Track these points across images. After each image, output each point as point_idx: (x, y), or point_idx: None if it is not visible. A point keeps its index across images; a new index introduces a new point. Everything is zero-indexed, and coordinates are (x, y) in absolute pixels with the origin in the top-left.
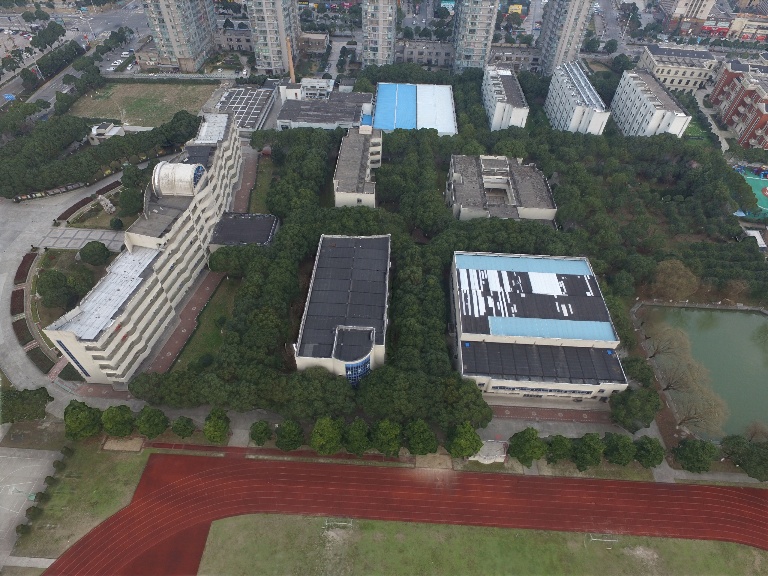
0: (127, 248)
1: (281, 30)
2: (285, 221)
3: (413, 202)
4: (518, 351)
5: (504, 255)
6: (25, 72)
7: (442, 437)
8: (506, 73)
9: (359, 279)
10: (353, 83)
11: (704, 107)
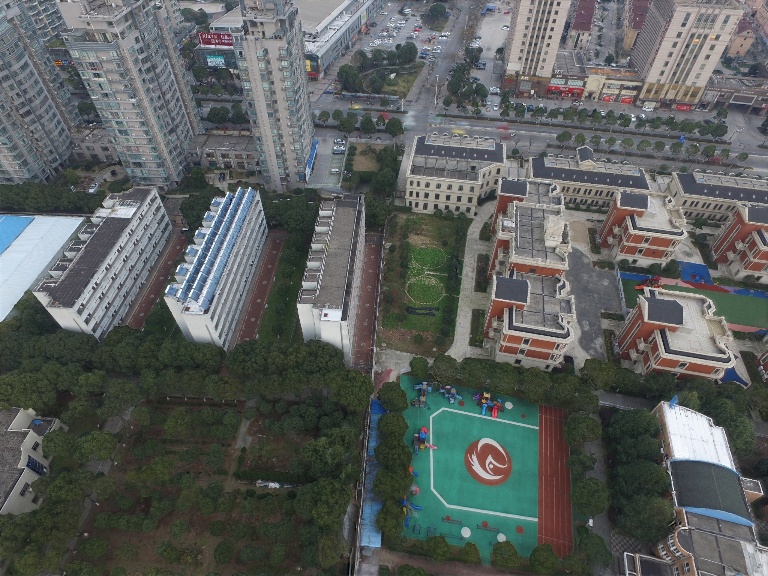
0: None
1: None
2: None
3: None
4: None
5: None
6: None
7: None
8: (124, 213)
9: None
10: None
11: (478, 239)
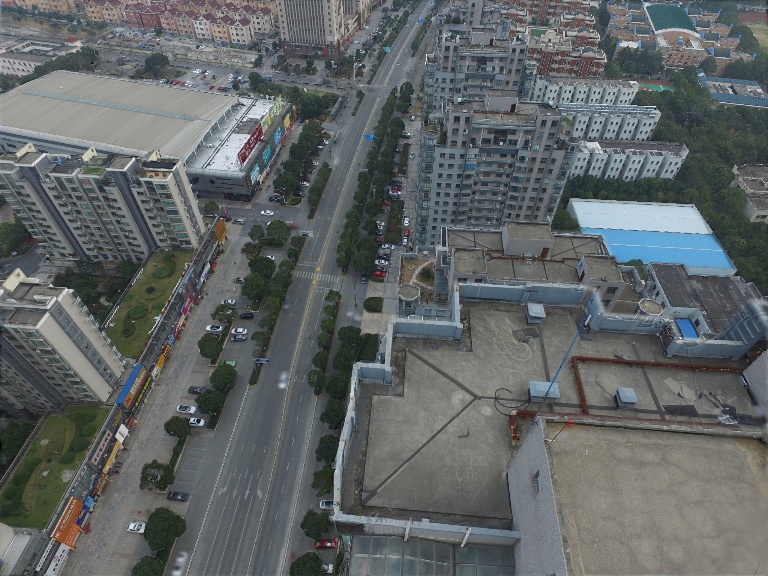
0: None
1: None
2: None
3: None
4: None
5: None
6: None
7: None
8: (595, 144)
9: None
10: None
11: None
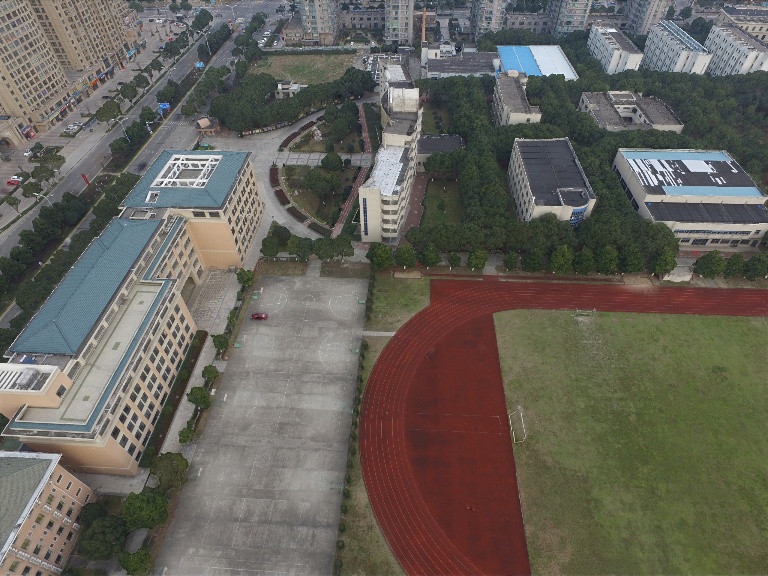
0: (385, 144)
1: (410, 5)
2: (470, 138)
3: (568, 122)
4: (689, 207)
5: (658, 150)
6: (202, 47)
7: (645, 261)
8: (612, 30)
9: (557, 164)
10: (475, 46)
11: None
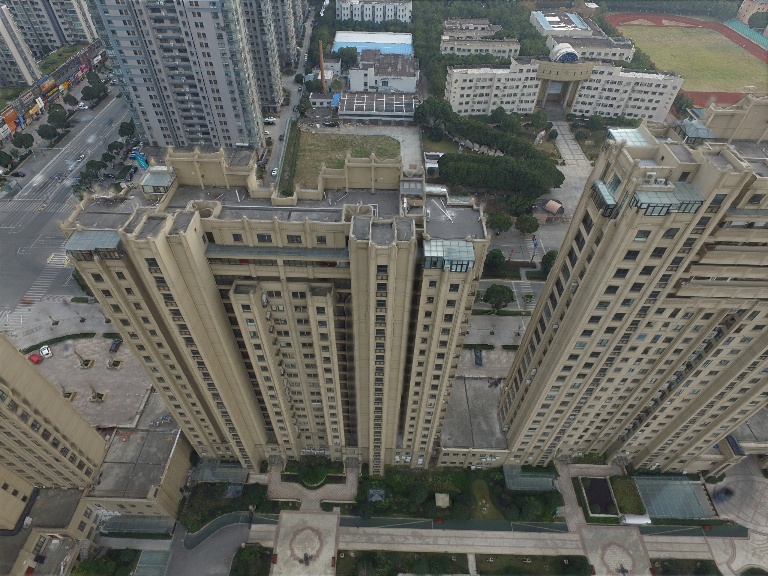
0: None
1: None
2: None
3: None
4: None
5: None
6: None
7: None
8: (356, 1)
9: None
10: (333, 59)
11: None
